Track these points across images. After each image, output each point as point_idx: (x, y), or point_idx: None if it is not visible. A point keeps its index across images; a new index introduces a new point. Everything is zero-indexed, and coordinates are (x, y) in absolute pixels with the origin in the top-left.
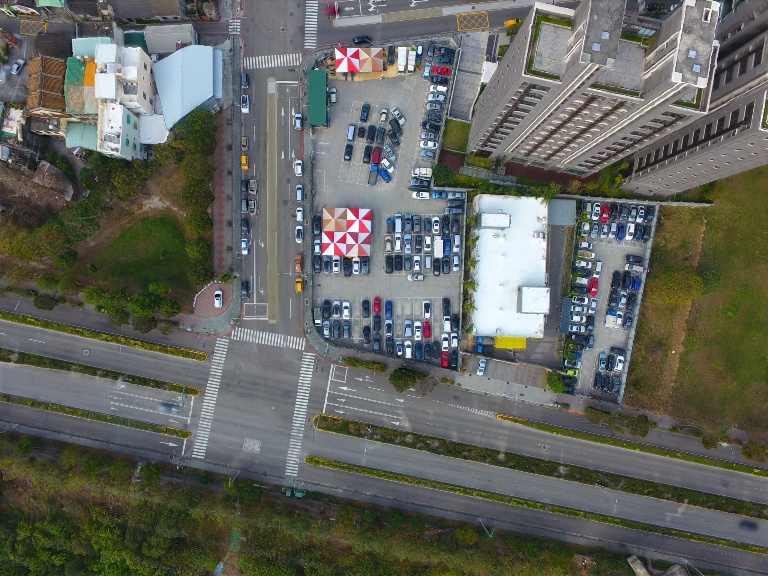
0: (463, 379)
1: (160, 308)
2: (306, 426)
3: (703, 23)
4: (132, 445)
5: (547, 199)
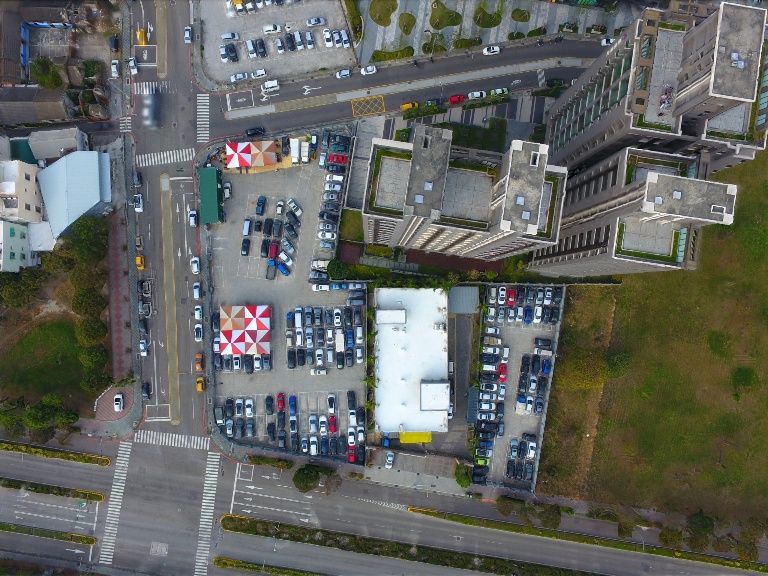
0: (372, 472)
1: (55, 419)
2: (213, 527)
3: (531, 167)
4: (38, 553)
5: (446, 290)
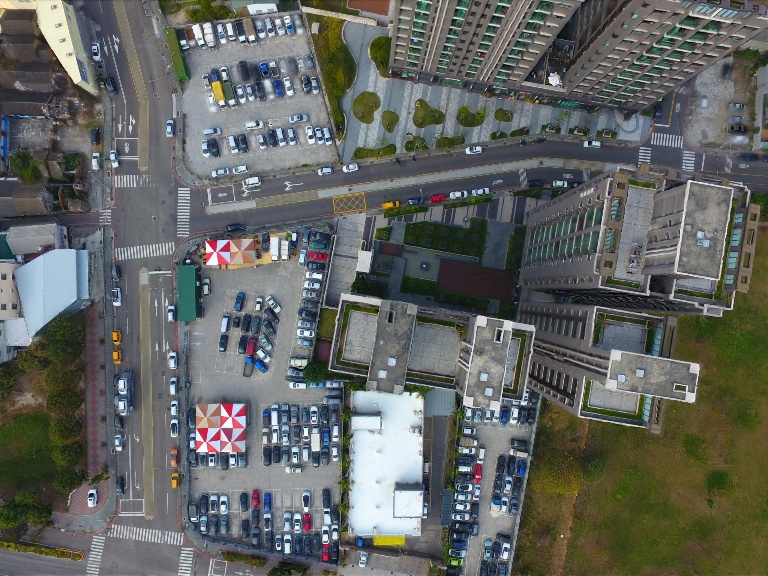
0: (346, 570)
1: (27, 517)
2: None
3: (495, 344)
4: None
5: (422, 394)
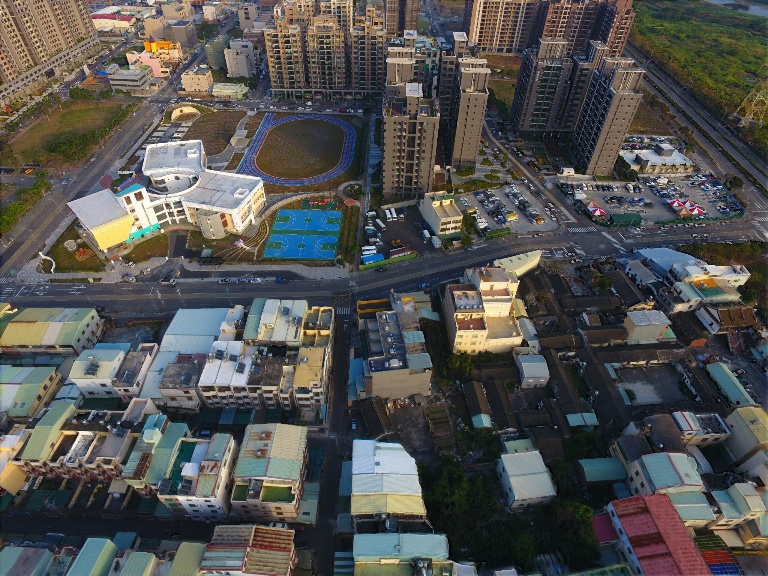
0: None
1: None
2: None
3: None
4: None
5: None
